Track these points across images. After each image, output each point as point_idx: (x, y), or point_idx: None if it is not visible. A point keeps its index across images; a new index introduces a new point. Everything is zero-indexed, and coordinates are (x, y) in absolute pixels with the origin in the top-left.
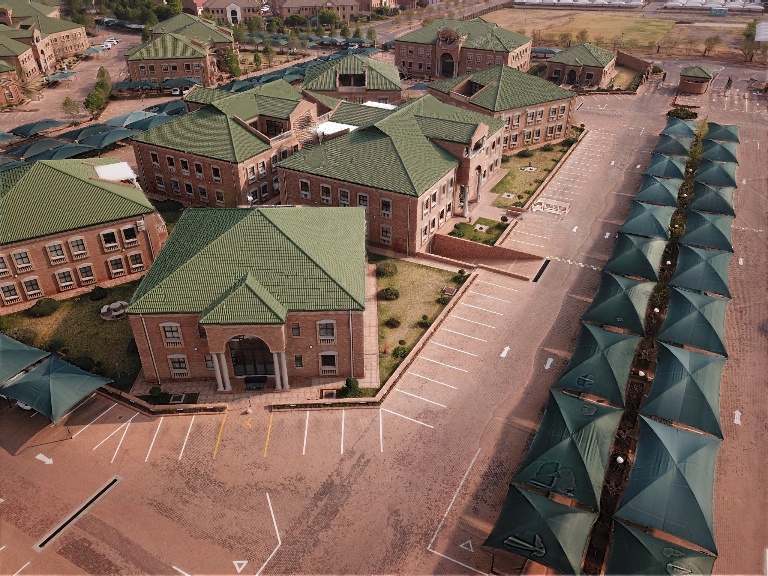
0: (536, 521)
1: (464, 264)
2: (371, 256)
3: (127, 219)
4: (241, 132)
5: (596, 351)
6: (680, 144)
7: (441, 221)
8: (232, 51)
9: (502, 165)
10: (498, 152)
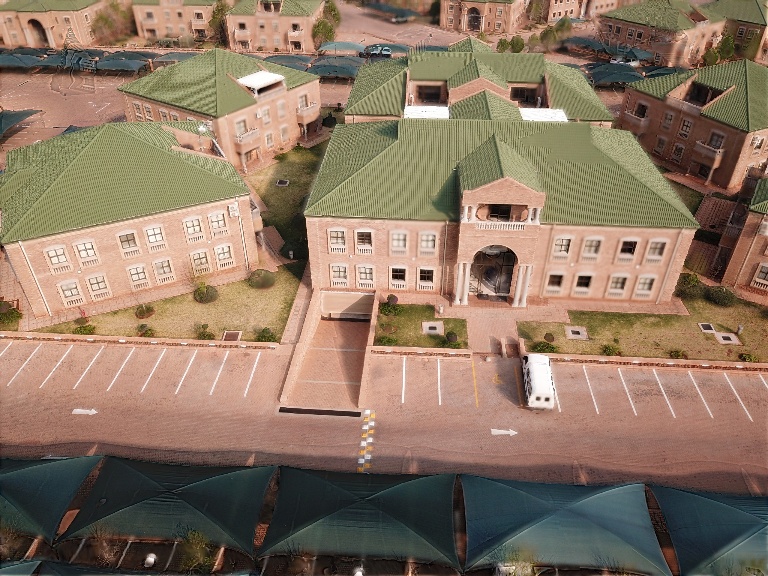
0: None
1: (301, 332)
2: (297, 263)
3: (203, 115)
4: (395, 88)
5: None
6: None
7: (397, 282)
8: (760, 37)
9: (697, 302)
10: (661, 269)
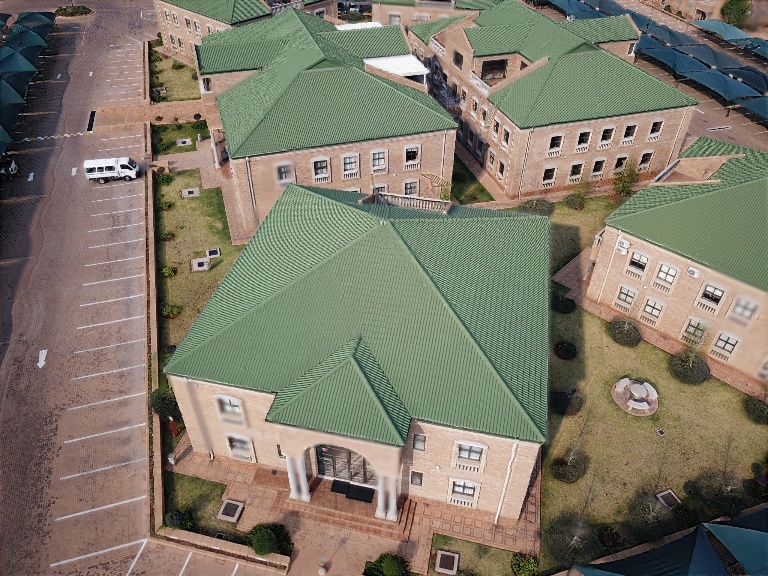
0: None
1: (164, 104)
2: None
3: None
4: None
5: (20, 51)
6: None
7: None
8: None
9: None
10: None
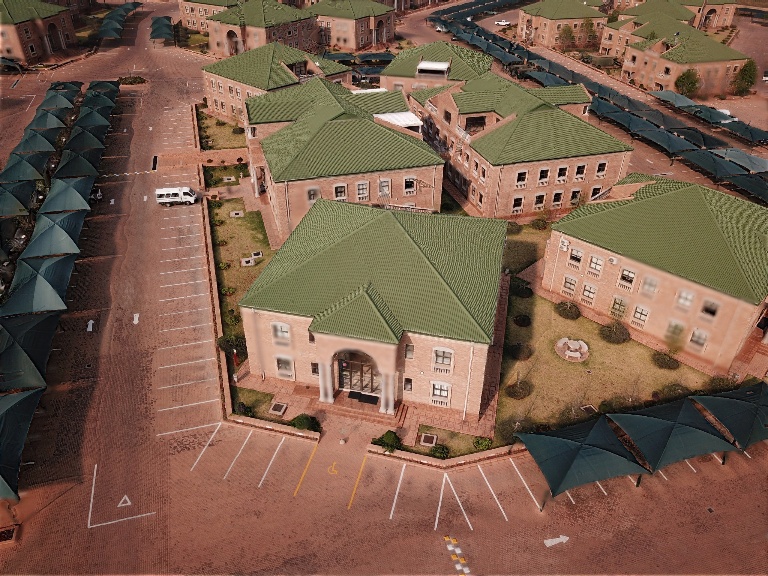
0: (106, 81)
1: (212, 151)
2: None
3: None
4: None
5: (97, 110)
6: (8, 328)
7: None
8: None
9: None
10: None
